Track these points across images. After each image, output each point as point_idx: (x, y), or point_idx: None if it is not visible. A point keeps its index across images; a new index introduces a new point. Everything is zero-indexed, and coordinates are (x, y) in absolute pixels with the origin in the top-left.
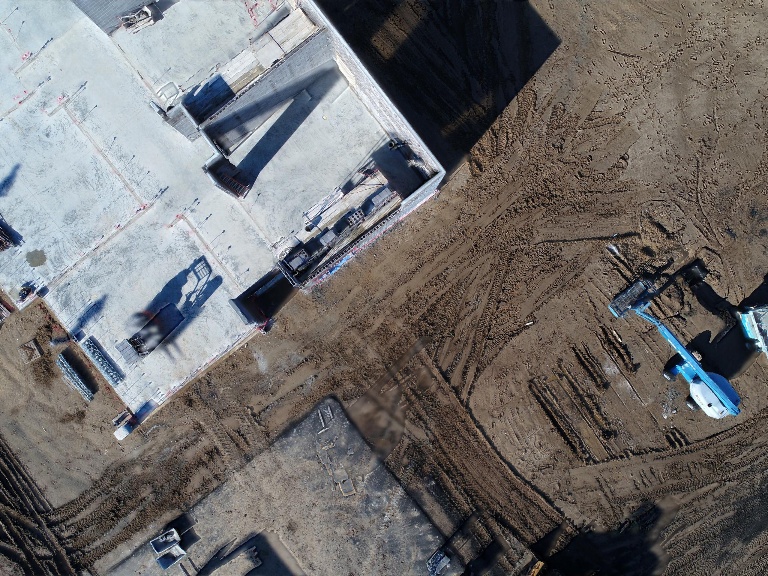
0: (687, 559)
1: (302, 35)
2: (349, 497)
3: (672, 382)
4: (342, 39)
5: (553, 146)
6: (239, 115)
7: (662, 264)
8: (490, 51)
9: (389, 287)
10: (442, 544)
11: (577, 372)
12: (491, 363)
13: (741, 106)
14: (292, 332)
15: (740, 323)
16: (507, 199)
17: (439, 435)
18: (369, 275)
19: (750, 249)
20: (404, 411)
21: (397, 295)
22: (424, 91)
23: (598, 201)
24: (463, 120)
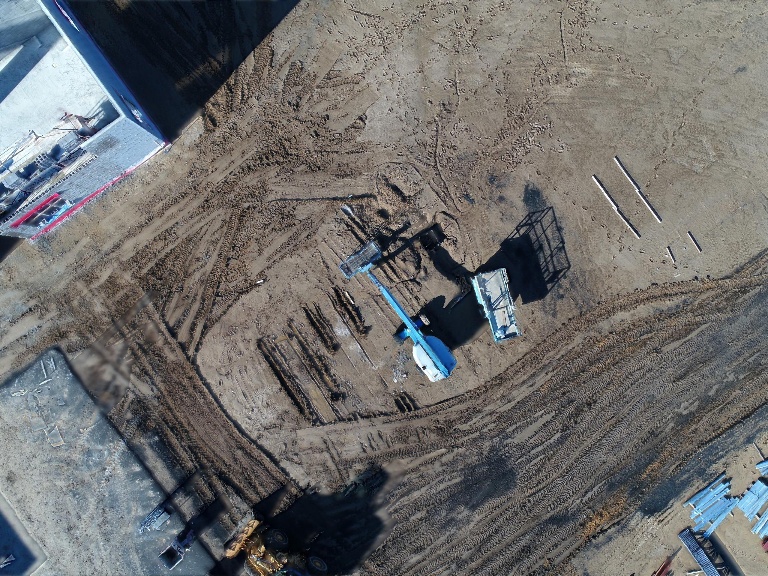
0: (413, 524)
1: None
2: (70, 450)
3: (403, 346)
4: None
5: (288, 103)
6: None
7: (398, 227)
8: (227, 5)
9: (117, 240)
10: (163, 500)
11: (308, 332)
12: (220, 320)
13: (483, 71)
14: (17, 281)
15: (473, 289)
16: (241, 155)
17: (165, 391)
18: (97, 227)
19: (488, 215)
20: (130, 365)
21: (125, 248)
22: (159, 43)
23: (334, 161)
24: (198, 74)
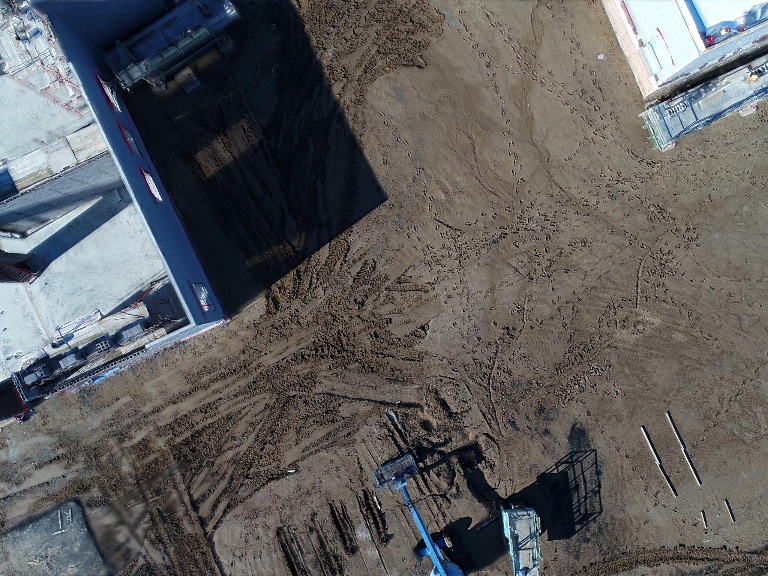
0: None
1: (99, 148)
2: None
3: None
4: (121, 169)
5: (354, 301)
6: (21, 211)
7: (439, 441)
8: (313, 192)
9: (158, 404)
10: None
11: (329, 529)
12: (244, 502)
13: (553, 303)
14: (50, 427)
15: (502, 517)
16: (297, 343)
17: (176, 561)
18: (141, 388)
19: (530, 446)
20: (146, 530)
21: (165, 414)
22: (238, 217)
23: (388, 365)
24: (270, 255)
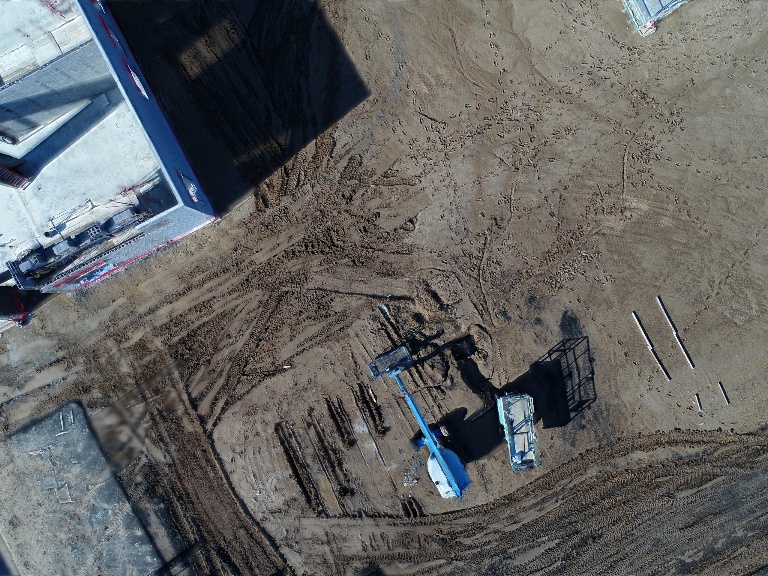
0: None
1: (84, 41)
2: (75, 504)
3: (419, 452)
4: (105, 54)
5: (342, 196)
6: (10, 108)
7: (431, 333)
8: (297, 90)
9: (153, 304)
10: (158, 567)
11: (326, 424)
12: (242, 399)
13: (539, 192)
14: (49, 331)
15: (497, 406)
16: (287, 240)
17: (177, 460)
18: (136, 289)
19: (522, 335)
20: (146, 429)
21: (160, 314)
22: (224, 117)
23: (379, 259)
24: (258, 153)
